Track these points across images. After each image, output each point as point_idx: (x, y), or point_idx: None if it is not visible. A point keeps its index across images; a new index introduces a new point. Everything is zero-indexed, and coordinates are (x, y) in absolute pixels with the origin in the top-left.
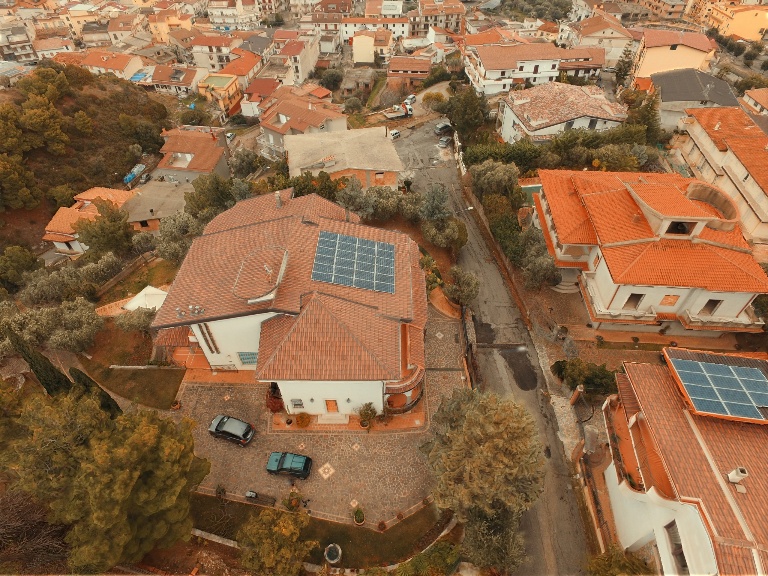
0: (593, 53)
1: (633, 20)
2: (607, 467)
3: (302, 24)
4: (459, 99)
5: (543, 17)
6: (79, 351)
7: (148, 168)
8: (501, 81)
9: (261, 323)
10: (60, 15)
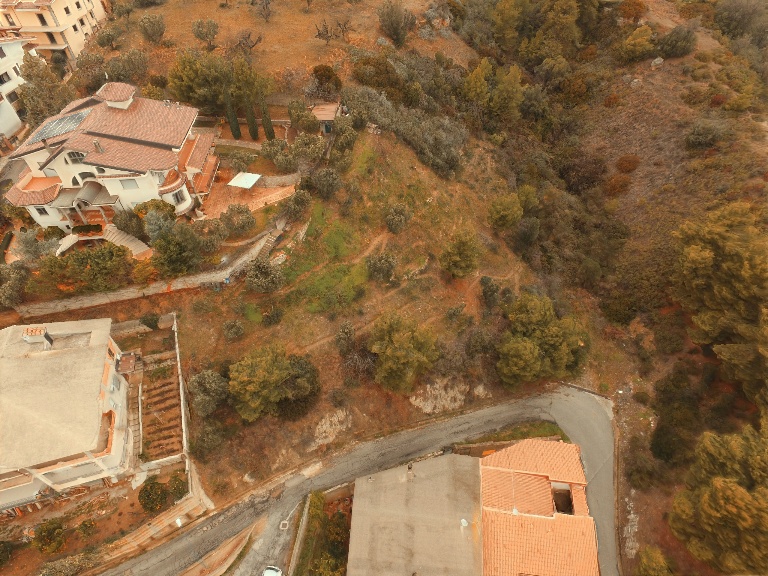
0: None
1: None
2: None
3: None
4: None
5: None
6: None
7: None
8: None
9: None
10: None
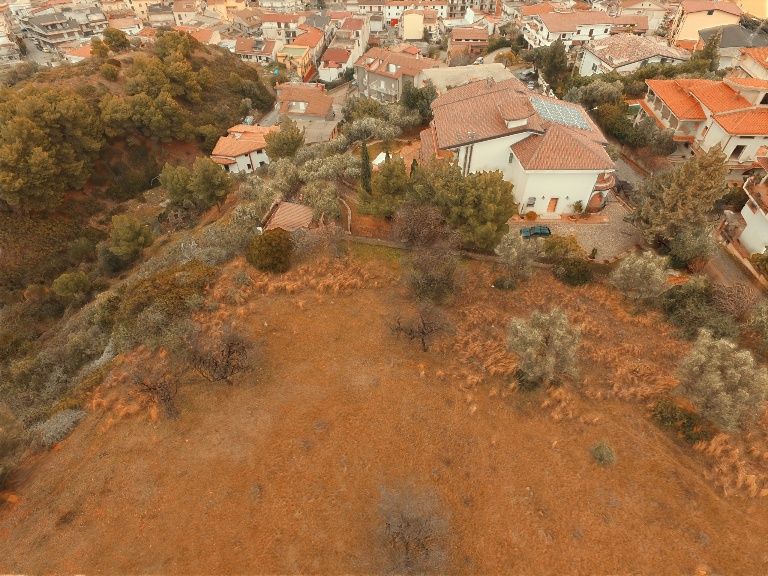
0: (638, 20)
1: None
2: (740, 235)
3: (348, 6)
4: (544, 48)
5: None
6: None
7: (255, 120)
8: (562, 42)
9: (510, 146)
10: None
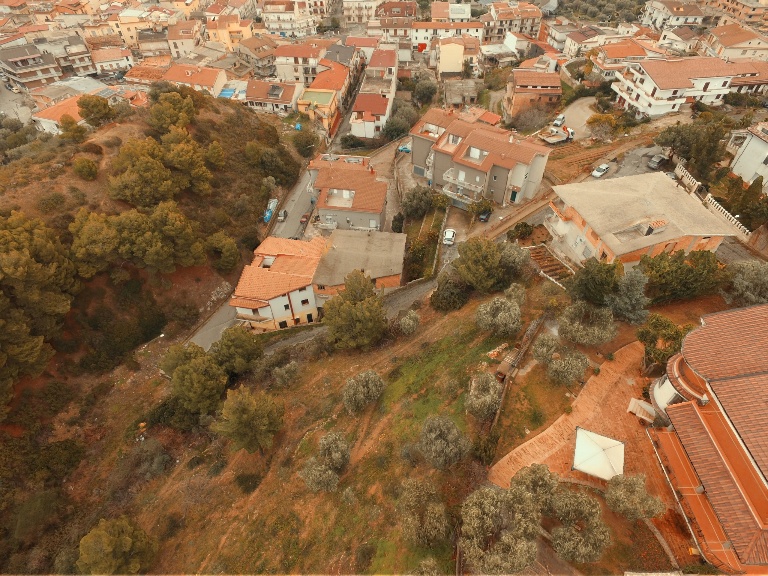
0: (758, 67)
1: (714, 23)
2: None
3: (370, 30)
4: (690, 130)
5: (616, 20)
6: None
7: (280, 202)
8: (674, 101)
9: None
10: (109, 22)
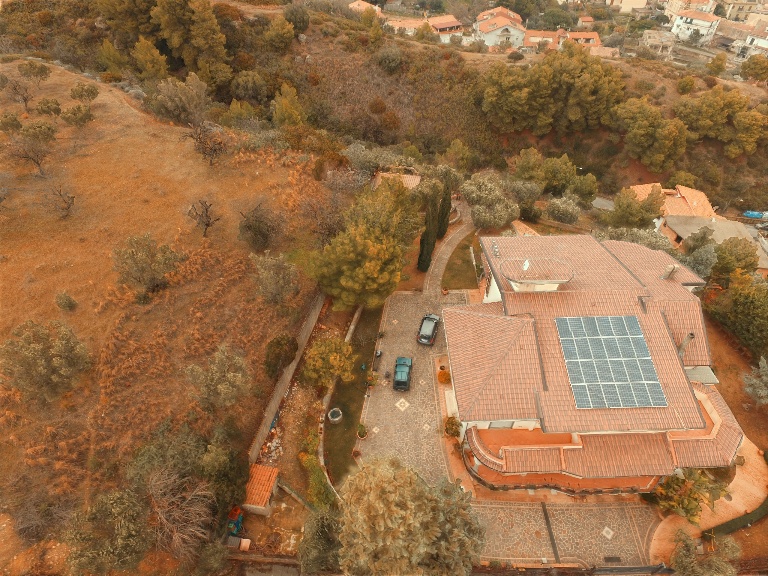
0: None
1: None
2: None
3: None
4: None
5: None
6: (474, 224)
7: None
8: None
9: None
10: None
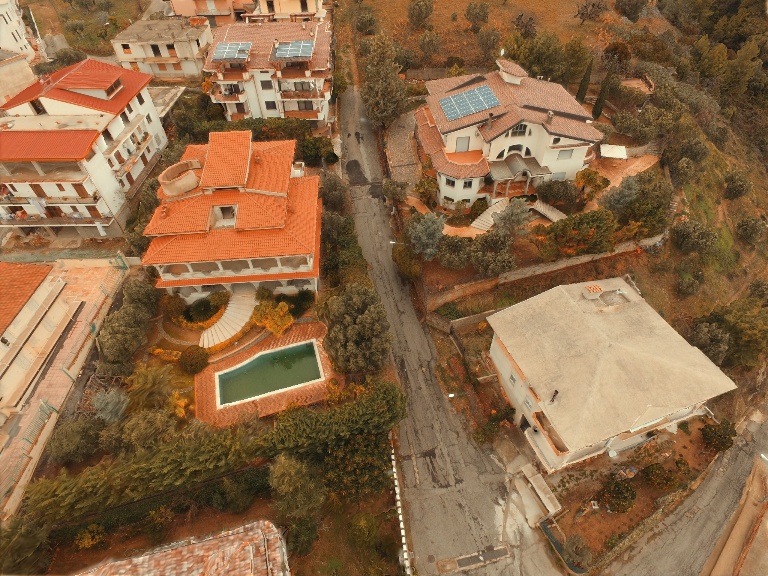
0: None
1: None
2: None
3: None
4: None
5: None
6: None
7: None
8: None
9: None
10: None
